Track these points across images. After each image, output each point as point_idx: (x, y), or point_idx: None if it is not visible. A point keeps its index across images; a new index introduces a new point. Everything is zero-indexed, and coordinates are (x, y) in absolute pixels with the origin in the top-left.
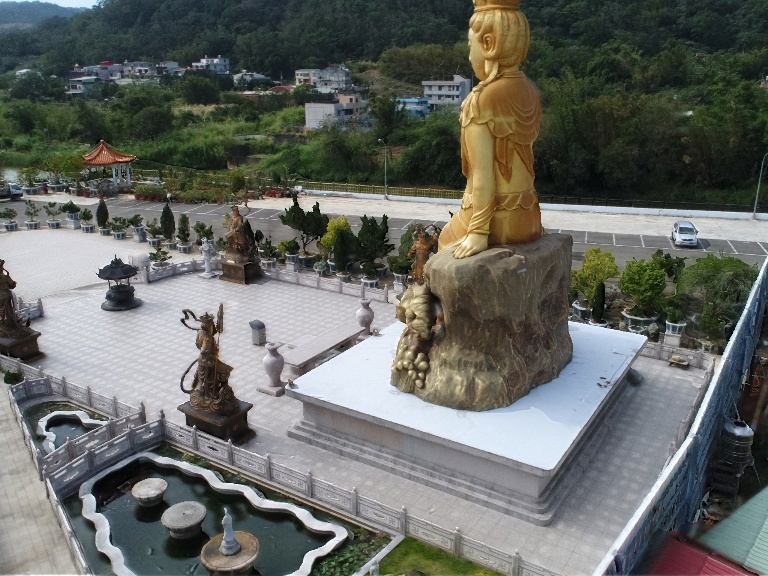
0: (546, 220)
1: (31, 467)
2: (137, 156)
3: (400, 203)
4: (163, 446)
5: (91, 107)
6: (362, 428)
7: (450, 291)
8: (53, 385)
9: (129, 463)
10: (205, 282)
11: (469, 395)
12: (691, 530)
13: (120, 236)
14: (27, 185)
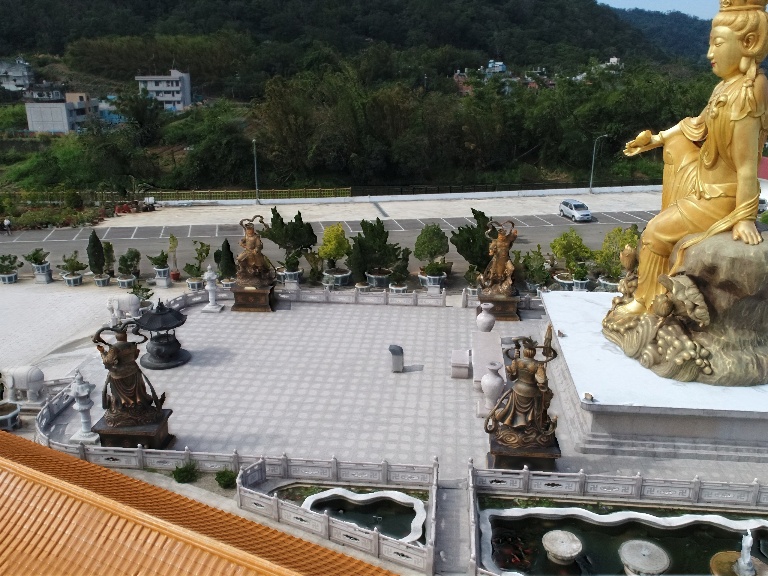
0: (439, 210)
1: (394, 567)
2: None
3: (278, 206)
4: (482, 499)
5: None
6: (670, 425)
7: (758, 276)
8: (266, 468)
9: None
10: (221, 317)
11: (760, 371)
12: None
13: (12, 279)
14: None
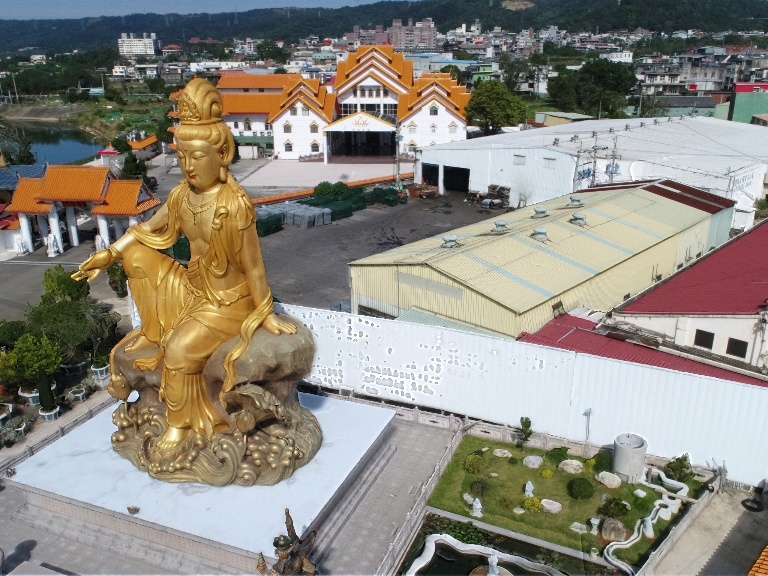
0: None
1: None
2: None
3: None
4: None
5: None
6: None
7: None
8: None
9: None
10: None
11: None
12: None
13: None
14: None
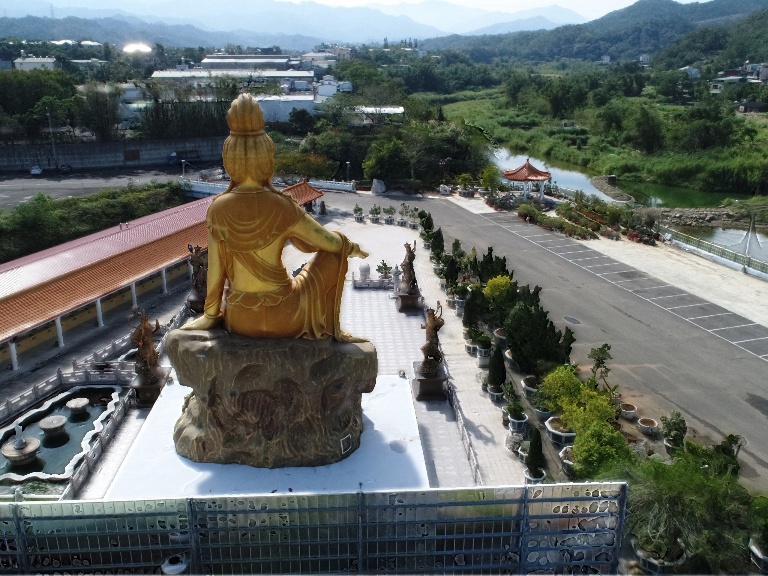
0: None
1: None
2: (663, 169)
3: (749, 280)
4: None
5: (651, 115)
6: None
7: None
8: None
9: (104, 388)
10: (383, 300)
11: (176, 437)
12: (9, 572)
13: (427, 246)
14: (463, 188)
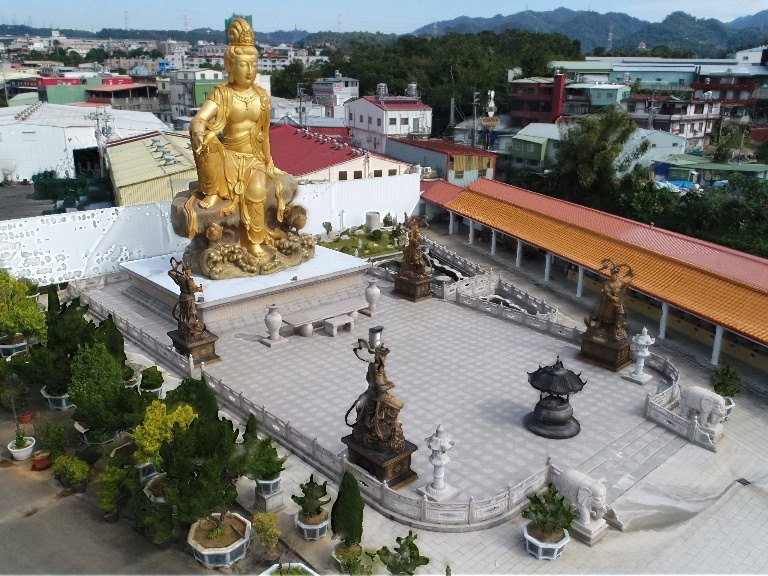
0: None
1: None
2: None
3: None
4: None
5: None
6: None
7: None
8: None
9: None
10: None
11: None
12: None
13: None
14: None
